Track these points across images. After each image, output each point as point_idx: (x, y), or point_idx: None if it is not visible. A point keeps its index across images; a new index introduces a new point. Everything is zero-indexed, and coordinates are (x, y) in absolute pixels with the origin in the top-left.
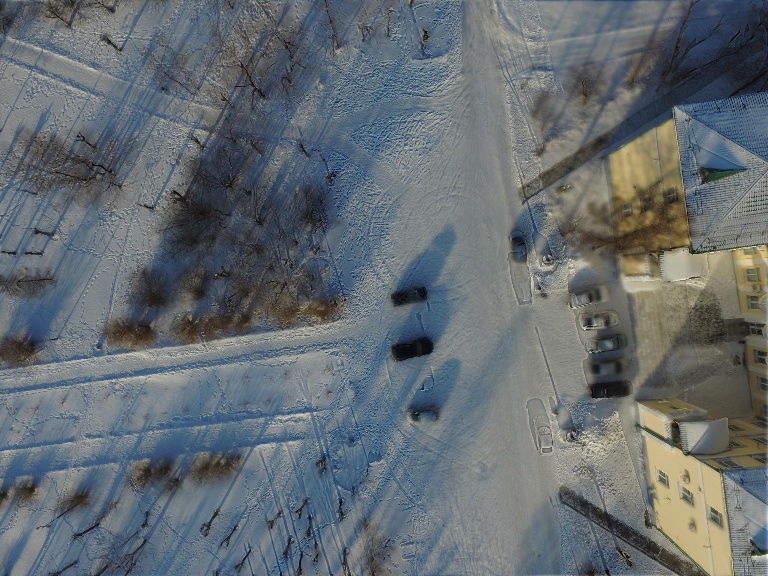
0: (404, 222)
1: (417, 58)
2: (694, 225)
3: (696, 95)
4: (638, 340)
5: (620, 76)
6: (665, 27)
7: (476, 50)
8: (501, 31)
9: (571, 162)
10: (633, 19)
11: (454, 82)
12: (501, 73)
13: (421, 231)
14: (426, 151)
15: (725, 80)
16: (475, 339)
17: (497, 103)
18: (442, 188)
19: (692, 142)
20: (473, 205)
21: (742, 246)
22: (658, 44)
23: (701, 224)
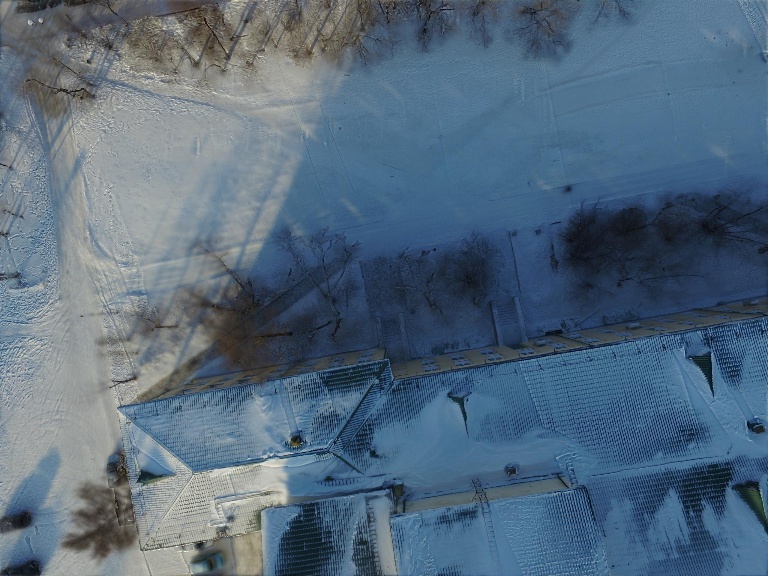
0: (10, 447)
1: (13, 288)
2: (140, 524)
3: (282, 315)
4: (236, 557)
5: (210, 298)
6: (251, 249)
7: (73, 276)
8: (95, 258)
9: (167, 383)
10: (220, 242)
11: (53, 308)
12: (98, 298)
13: (27, 455)
14: (28, 377)
15: (308, 300)
16: (83, 560)
17: (95, 327)
18: (45, 412)
19: (133, 445)
20: (76, 428)
21: (187, 543)
22: (246, 265)
23: (145, 524)
